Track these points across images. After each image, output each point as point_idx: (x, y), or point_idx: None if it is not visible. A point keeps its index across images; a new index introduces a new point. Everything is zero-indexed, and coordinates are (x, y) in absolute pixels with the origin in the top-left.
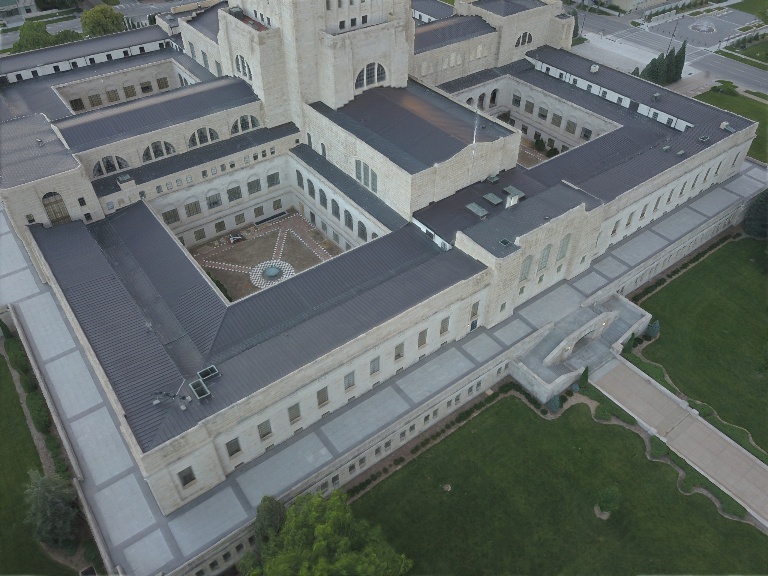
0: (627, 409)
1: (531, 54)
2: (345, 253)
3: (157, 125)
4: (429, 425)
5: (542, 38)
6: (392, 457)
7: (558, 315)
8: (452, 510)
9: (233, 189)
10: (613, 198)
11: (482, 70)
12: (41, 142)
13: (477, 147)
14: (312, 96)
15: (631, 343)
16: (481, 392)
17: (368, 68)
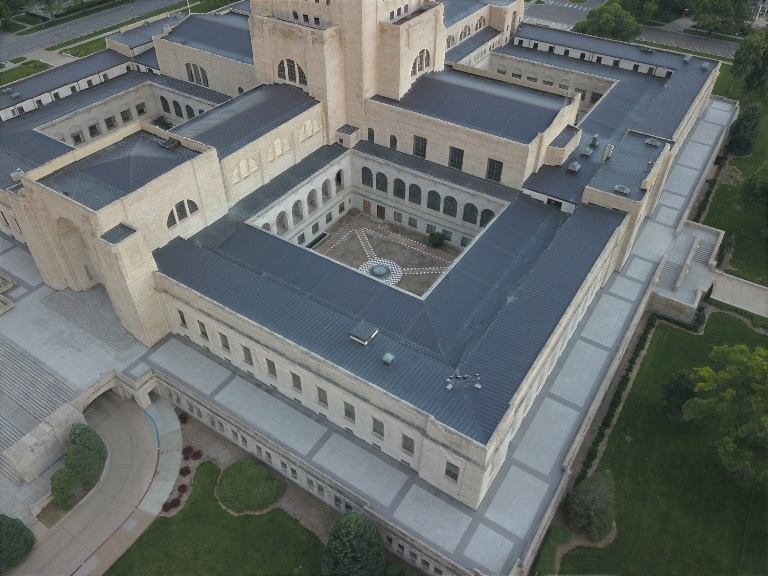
0: None
1: None
2: None
3: None
4: None
5: None
6: None
7: None
8: None
9: None
10: (93, 56)
11: None
12: None
13: None
14: None
15: None
16: None
17: None
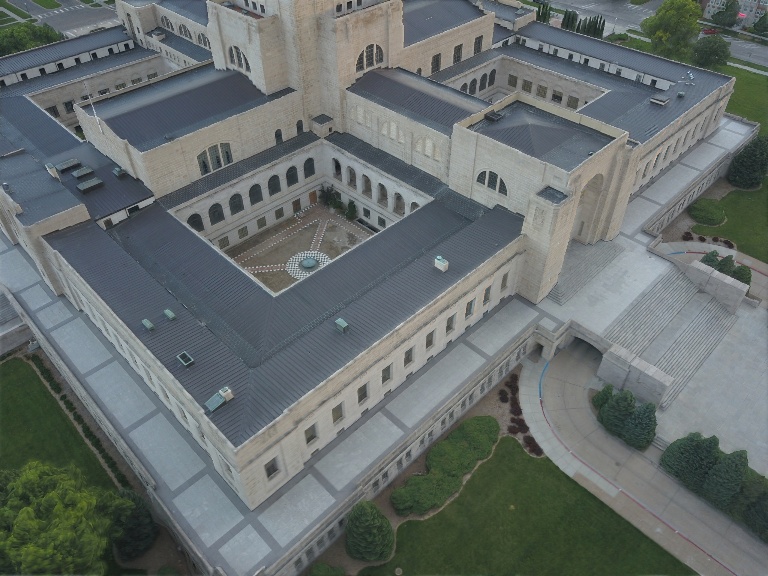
0: None
1: (496, 210)
2: (61, 126)
3: (193, 16)
4: None
5: None
6: None
7: (1, 272)
8: None
9: None
10: (60, 251)
11: (434, 175)
12: None
13: (103, 126)
14: None
15: None
16: None
17: None
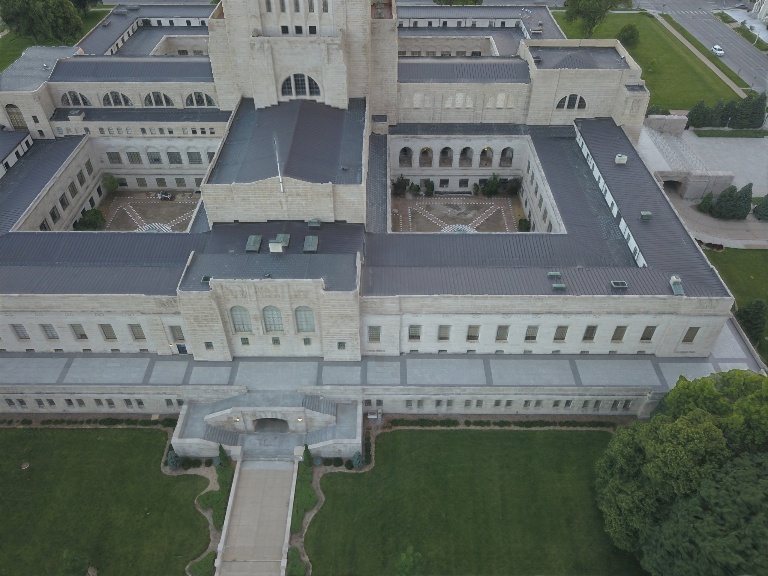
0: (229, 511)
1: (580, 122)
2: (131, 232)
3: (122, 78)
4: (77, 410)
5: (604, 107)
6: (26, 416)
7: (267, 385)
8: (4, 484)
9: (174, 153)
10: None
11: (505, 122)
12: (46, 67)
13: (288, 182)
14: (250, 91)
15: (304, 454)
16: (148, 412)
17: (298, 78)
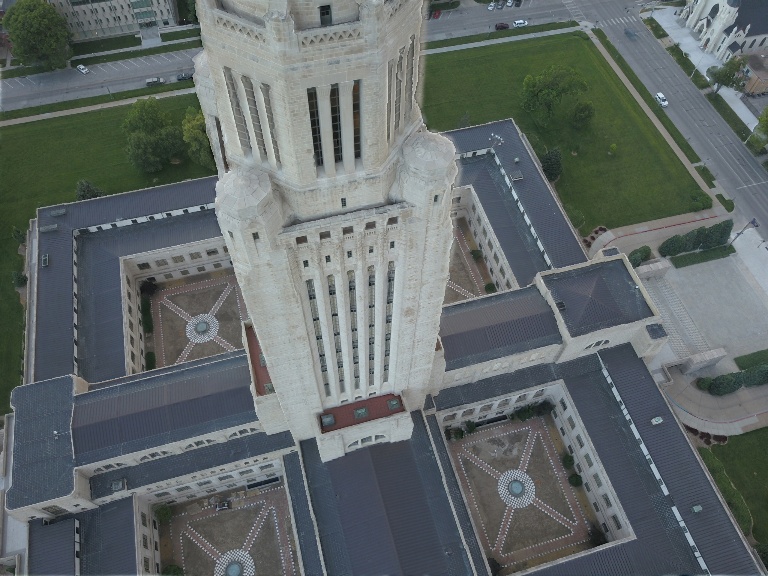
0: None
1: (604, 354)
2: None
3: (157, 437)
4: None
5: (625, 339)
6: None
7: None
8: None
9: None
10: None
11: (536, 364)
12: (57, 434)
13: None
14: (307, 436)
15: None
16: None
17: None
